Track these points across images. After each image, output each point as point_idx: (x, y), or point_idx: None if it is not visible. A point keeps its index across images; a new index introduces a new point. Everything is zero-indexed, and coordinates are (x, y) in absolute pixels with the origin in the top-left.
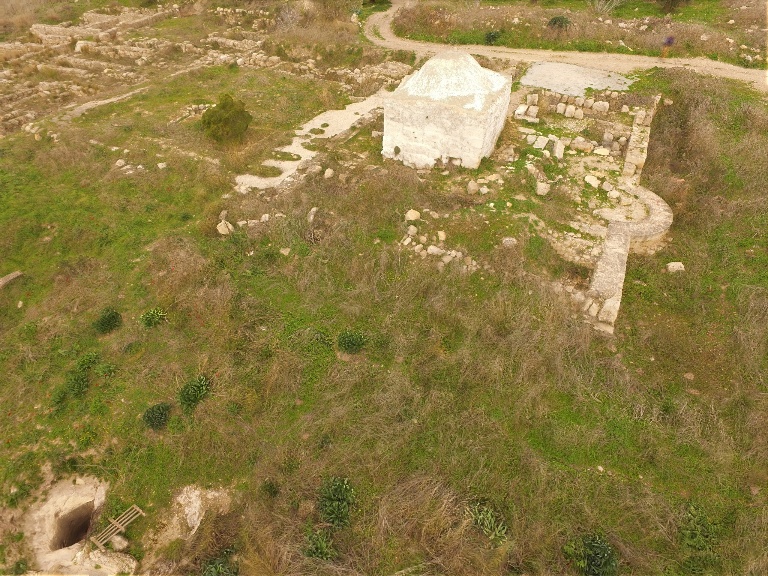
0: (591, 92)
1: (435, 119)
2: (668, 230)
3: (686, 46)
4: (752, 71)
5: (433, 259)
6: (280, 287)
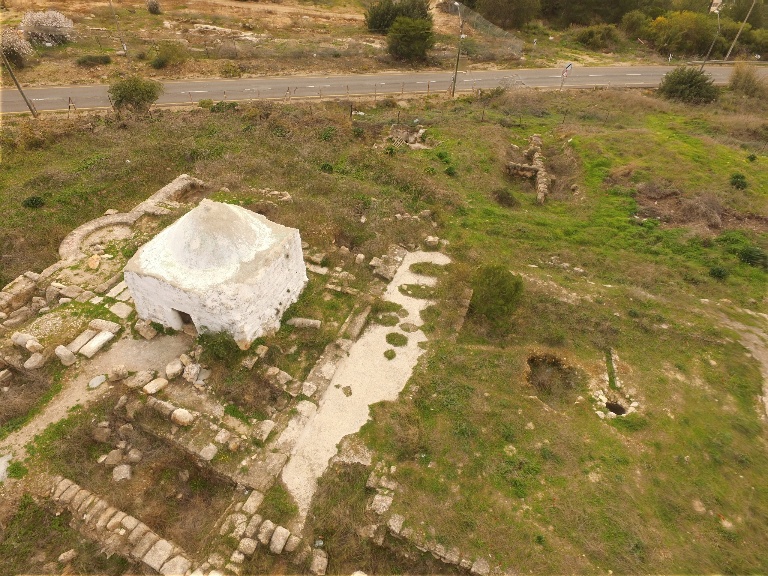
0: None
1: None
2: None
3: None
4: None
5: None
6: (370, 187)
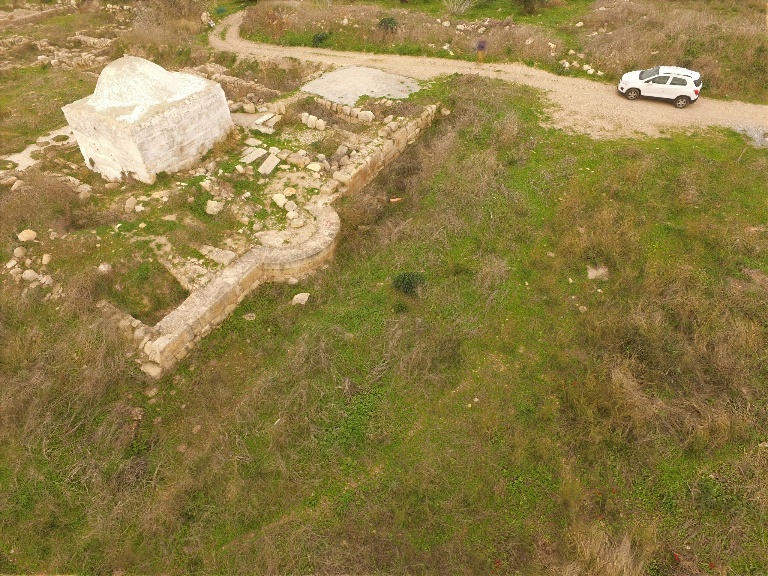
0: (365, 100)
1: (100, 131)
2: (332, 256)
3: (506, 51)
4: (562, 79)
5: (21, 285)
6: None
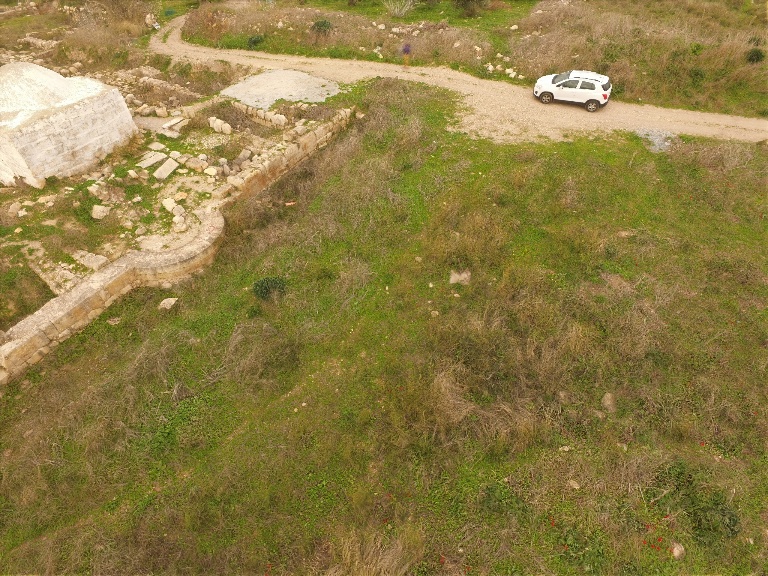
0: (281, 104)
1: None
2: (212, 260)
3: (433, 54)
4: (484, 82)
5: None
6: None
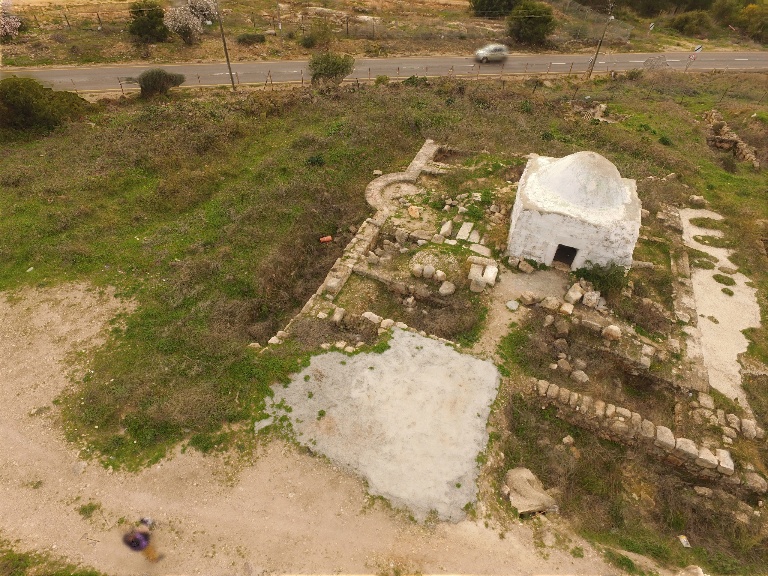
0: None
1: None
2: None
3: None
4: None
5: None
6: None
